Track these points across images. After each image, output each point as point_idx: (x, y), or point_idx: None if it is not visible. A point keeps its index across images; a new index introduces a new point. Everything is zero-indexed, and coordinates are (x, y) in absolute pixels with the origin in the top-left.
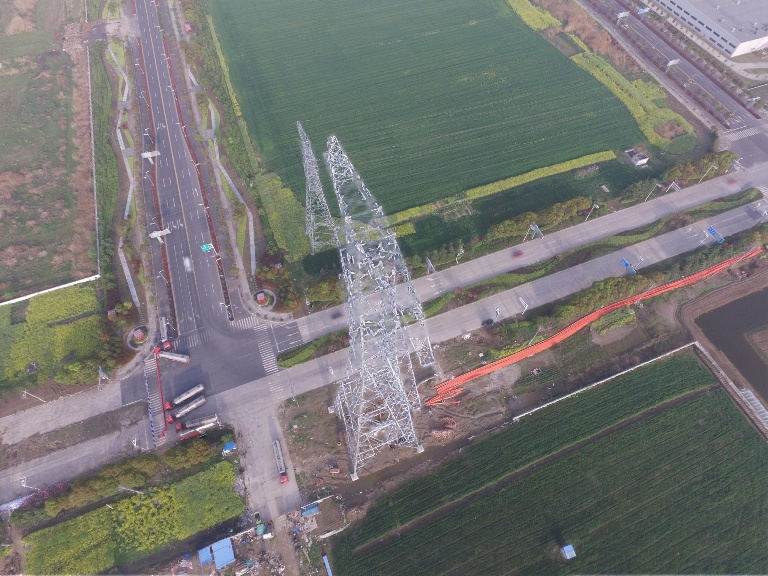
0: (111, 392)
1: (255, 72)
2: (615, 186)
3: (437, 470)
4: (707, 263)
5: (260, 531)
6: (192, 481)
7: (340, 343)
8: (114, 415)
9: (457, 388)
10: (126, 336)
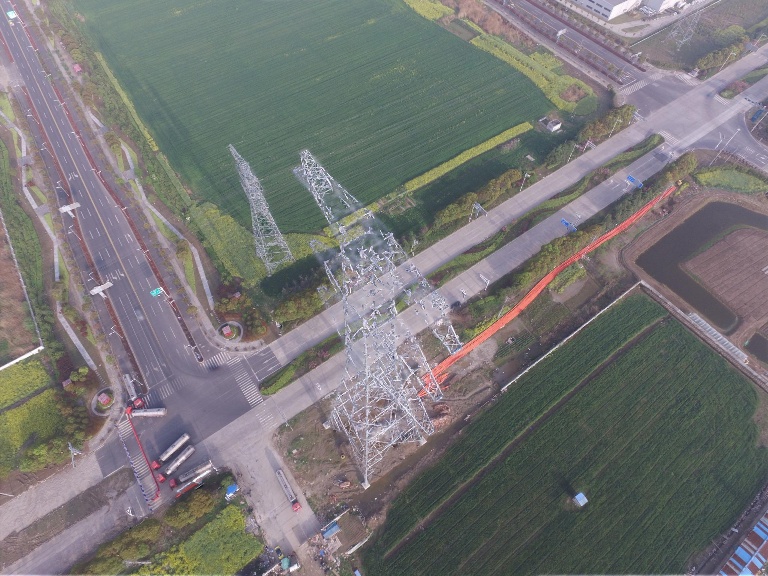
0: (87, 467)
1: (162, 103)
2: (538, 154)
3: (443, 457)
4: (634, 208)
5: (285, 565)
6: (201, 535)
7: (319, 358)
8: (97, 490)
9: (442, 374)
10: (89, 404)
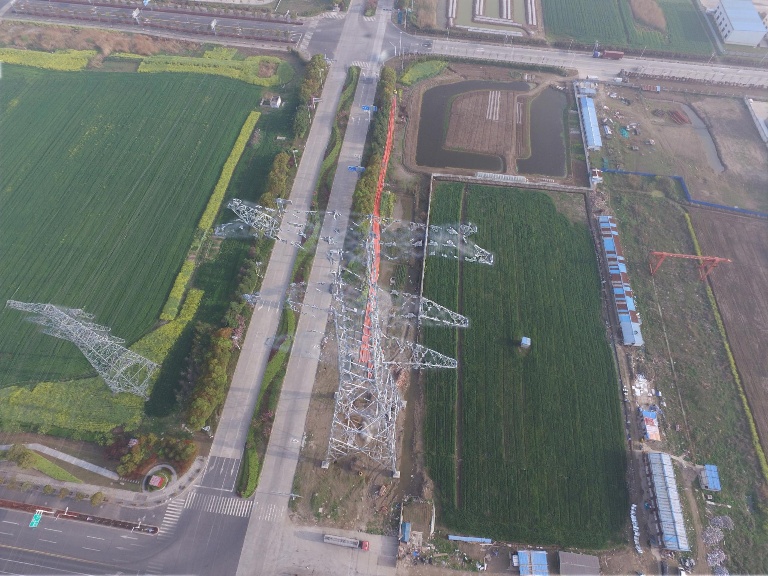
0: None
1: None
2: (284, 131)
3: (427, 400)
4: (385, 128)
5: None
6: None
7: (266, 422)
8: None
9: None
10: None
